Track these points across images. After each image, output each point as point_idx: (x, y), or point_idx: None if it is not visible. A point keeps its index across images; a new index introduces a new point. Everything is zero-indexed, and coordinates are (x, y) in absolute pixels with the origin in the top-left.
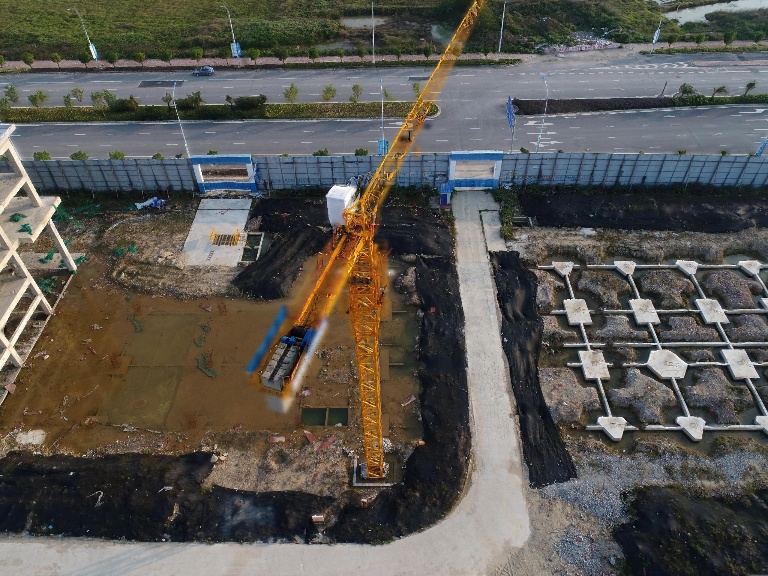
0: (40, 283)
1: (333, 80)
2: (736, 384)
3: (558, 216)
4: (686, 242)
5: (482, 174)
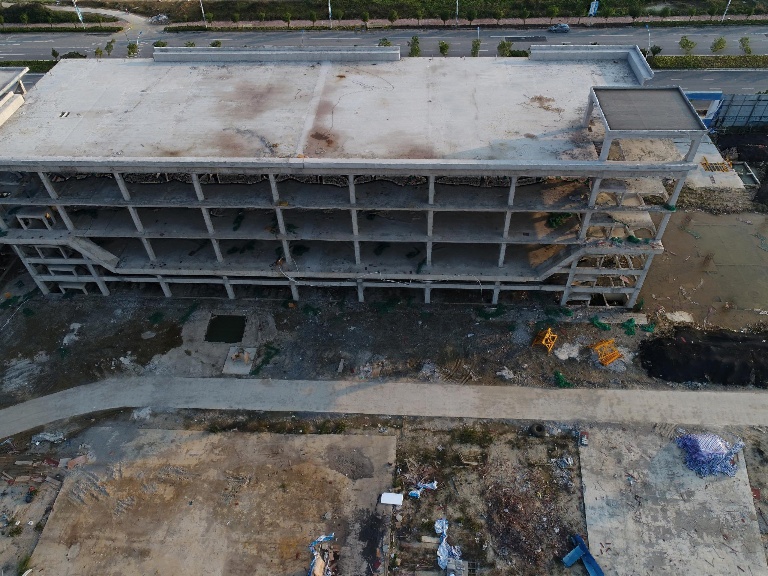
0: None
1: (691, 36)
2: None
3: None
4: None
5: None
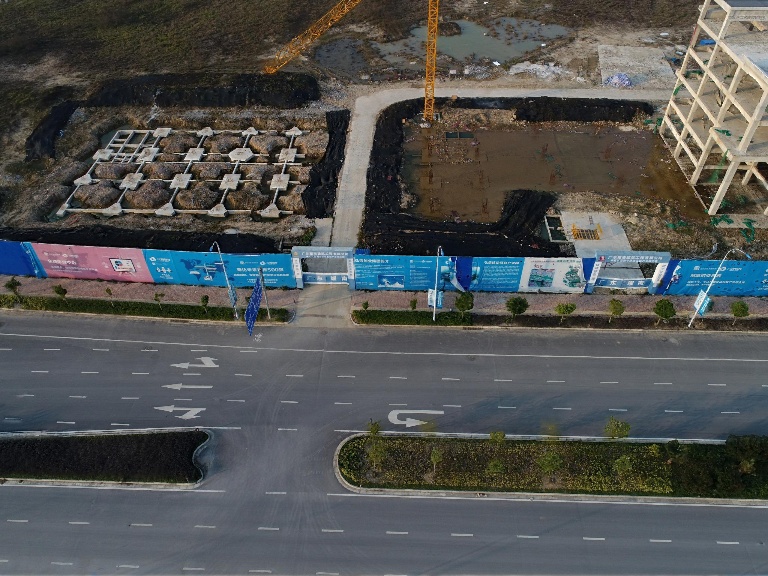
0: (727, 202)
1: None
2: (206, 150)
3: (254, 237)
4: (151, 221)
5: (309, 308)
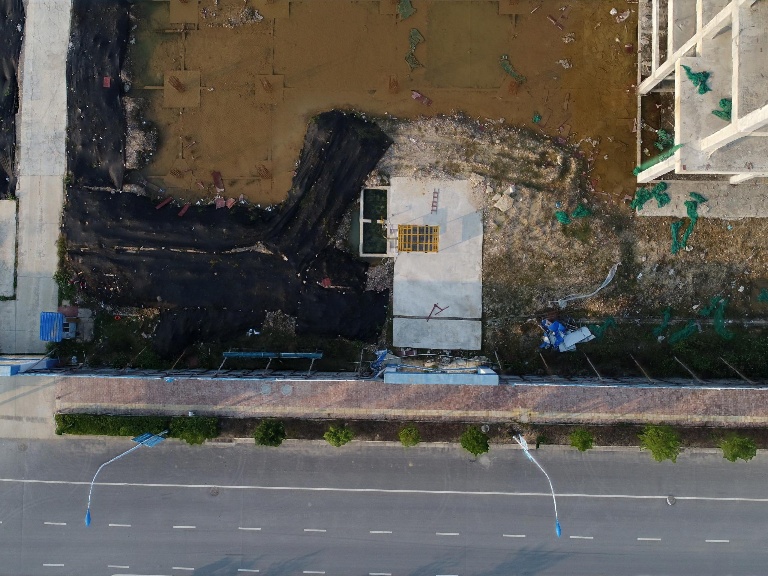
0: None
1: None
2: None
3: None
4: None
5: None
